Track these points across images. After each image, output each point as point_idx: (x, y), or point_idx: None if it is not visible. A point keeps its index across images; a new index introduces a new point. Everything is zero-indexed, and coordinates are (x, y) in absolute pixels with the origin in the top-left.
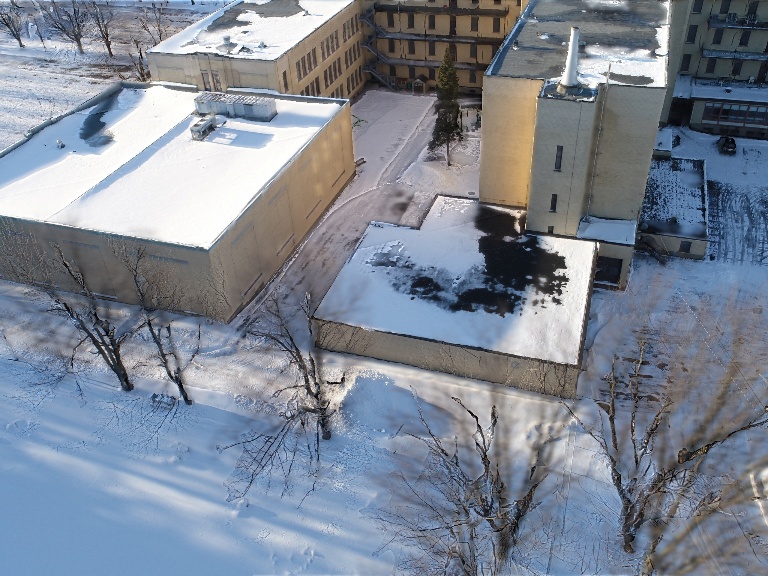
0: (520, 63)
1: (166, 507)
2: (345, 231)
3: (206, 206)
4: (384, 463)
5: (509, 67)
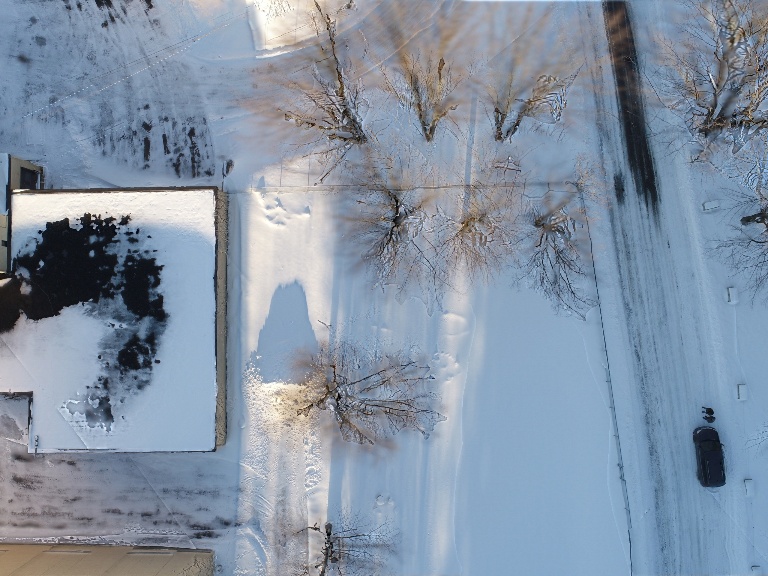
0: None
1: (435, 483)
2: (3, 501)
3: None
4: (345, 330)
5: None
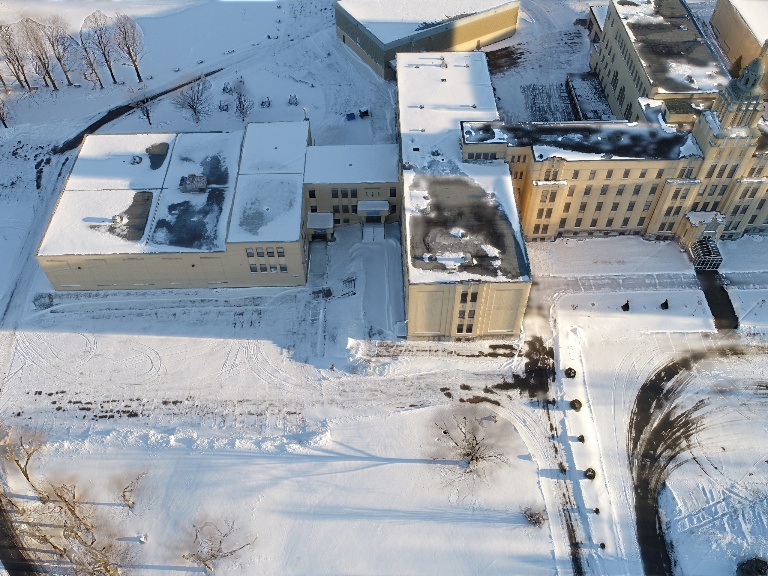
0: (676, 6)
1: None
2: None
3: (750, 6)
4: None
5: (678, 3)
